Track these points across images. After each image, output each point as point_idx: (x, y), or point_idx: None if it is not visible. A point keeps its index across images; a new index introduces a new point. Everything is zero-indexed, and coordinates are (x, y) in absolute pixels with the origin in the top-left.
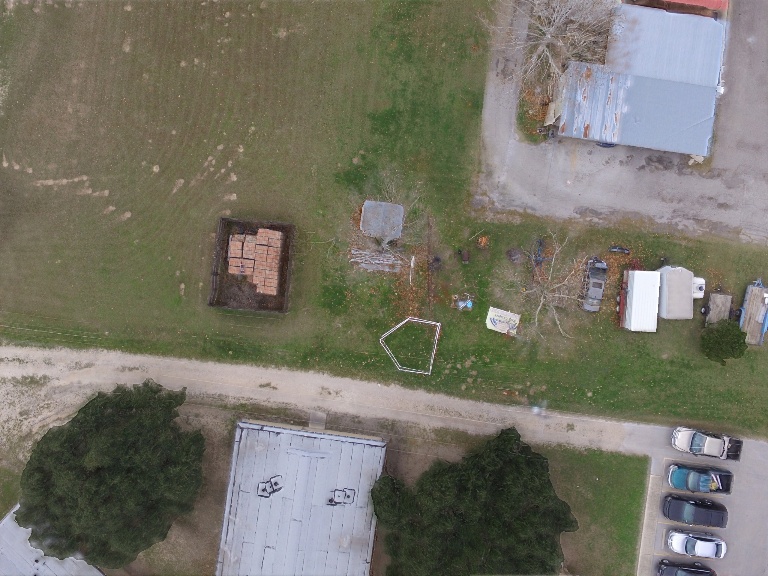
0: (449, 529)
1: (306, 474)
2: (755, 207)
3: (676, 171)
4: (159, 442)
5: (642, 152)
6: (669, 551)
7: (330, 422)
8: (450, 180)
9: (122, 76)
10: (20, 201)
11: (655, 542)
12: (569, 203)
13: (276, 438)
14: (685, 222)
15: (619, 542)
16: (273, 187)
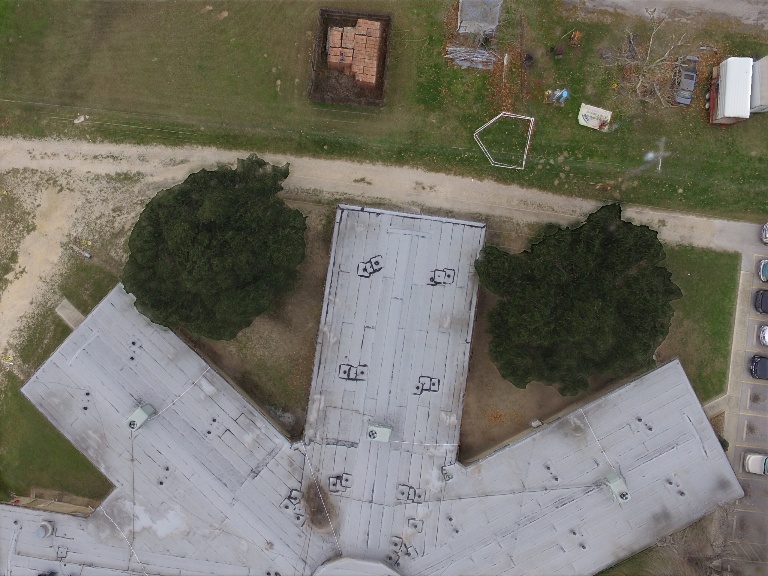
0: (561, 281)
1: (407, 252)
2: None
3: None
4: (267, 205)
5: None
6: (761, 347)
7: None
8: None
9: None
10: (117, 3)
11: (747, 338)
12: (658, 4)
13: (376, 218)
14: None
15: (711, 337)
16: None
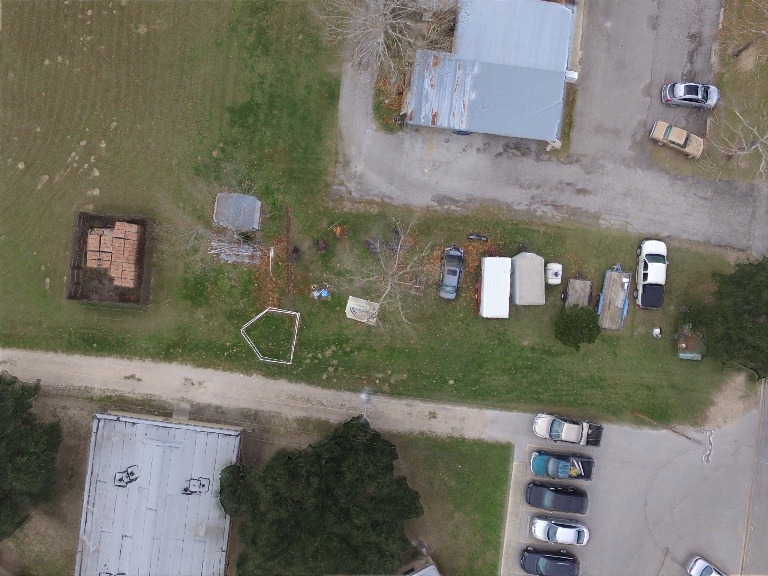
0: (284, 515)
1: (160, 463)
2: (615, 192)
3: (534, 157)
4: (7, 432)
5: (499, 139)
6: (534, 538)
7: (194, 413)
8: (307, 171)
9: None
10: None
11: (520, 529)
12: (426, 191)
13: (132, 428)
14: (543, 208)
15: (483, 530)
16: (135, 181)
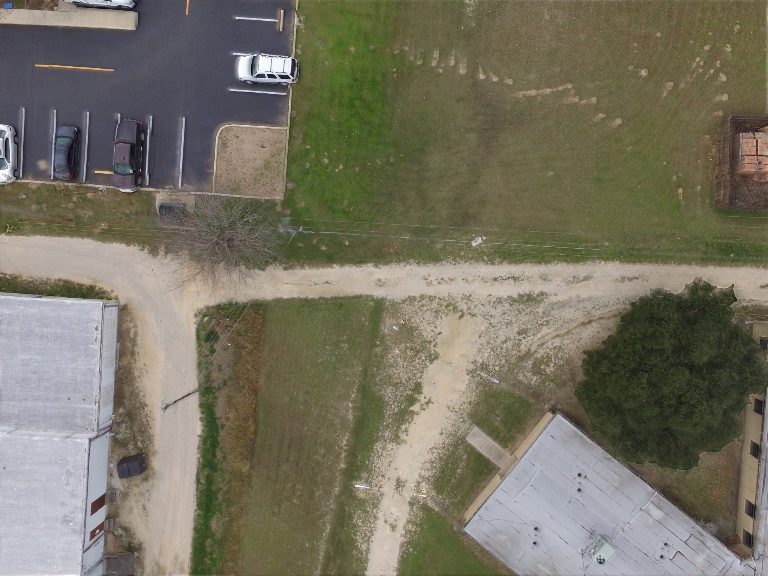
0: None
1: None
2: None
3: None
4: (740, 335)
5: None
6: None
7: None
8: None
9: None
10: (502, 114)
11: None
12: None
13: None
14: None
15: None
16: (763, 85)
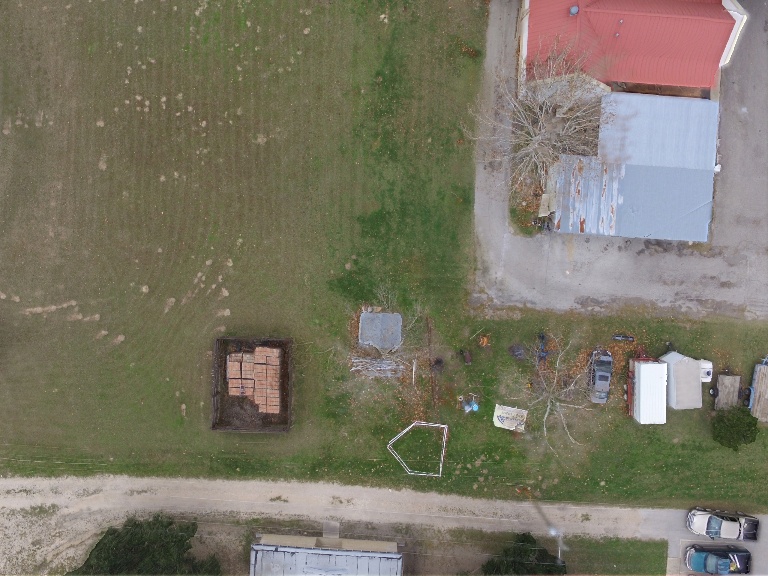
0: None
1: None
2: (759, 282)
3: (677, 252)
4: None
5: None
6: None
7: (344, 530)
8: (446, 280)
9: (102, 195)
10: (10, 331)
11: None
12: (569, 294)
13: (291, 558)
14: (689, 304)
15: None
16: (267, 300)
